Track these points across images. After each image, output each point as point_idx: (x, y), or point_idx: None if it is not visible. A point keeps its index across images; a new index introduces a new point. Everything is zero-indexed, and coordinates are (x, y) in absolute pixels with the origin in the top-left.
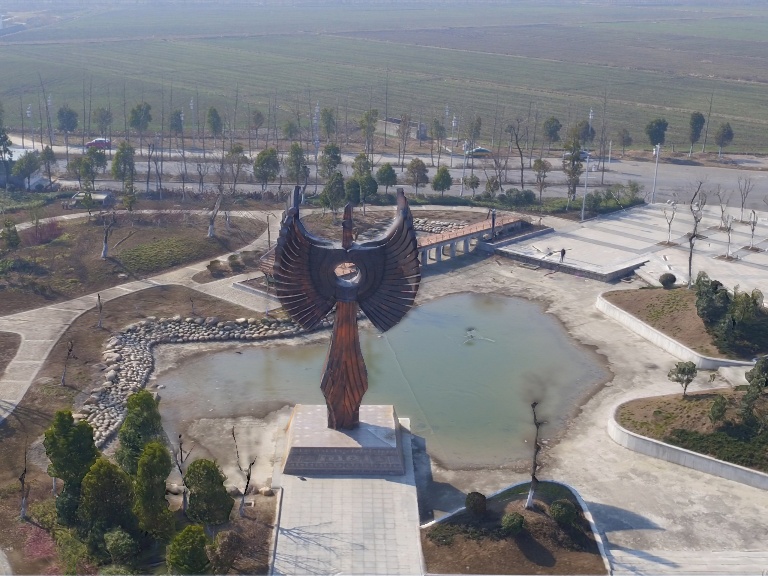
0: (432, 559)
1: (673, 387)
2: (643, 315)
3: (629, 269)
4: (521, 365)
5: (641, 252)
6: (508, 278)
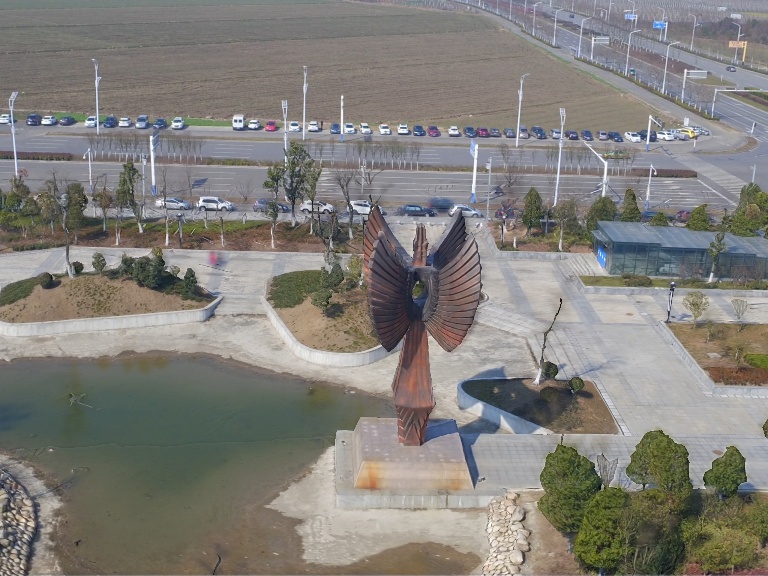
0: (599, 431)
1: (242, 335)
2: (90, 313)
3: None
4: (162, 388)
5: None
6: None
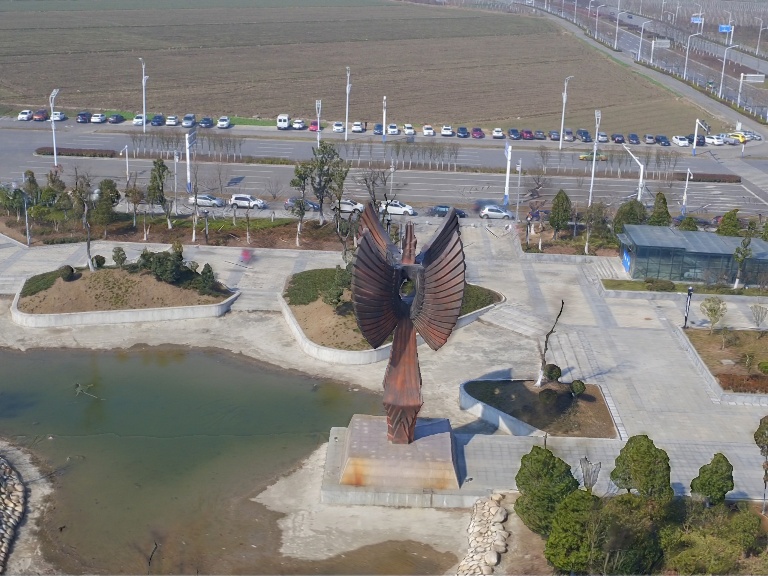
0: (596, 435)
1: (255, 331)
2: (107, 306)
3: None
4: (169, 380)
5: None
6: None
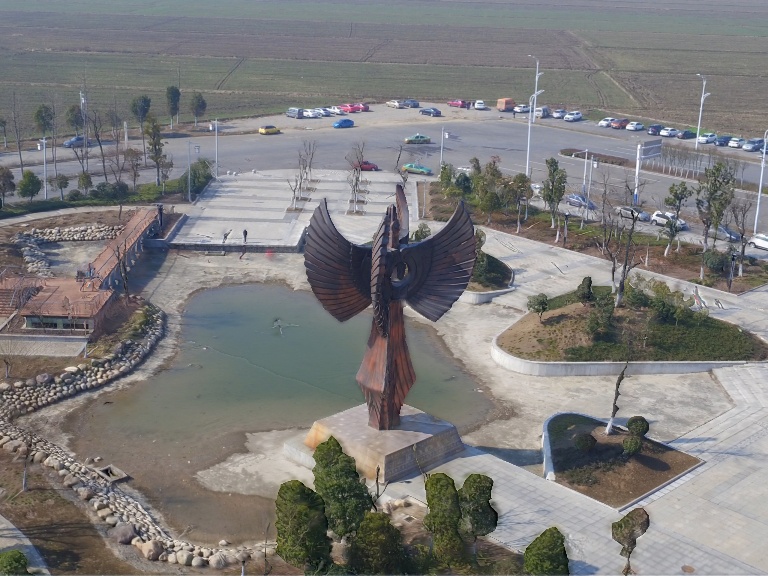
0: (601, 498)
1: (484, 323)
2: None
3: (303, 237)
4: (354, 339)
5: (288, 221)
6: (215, 268)
